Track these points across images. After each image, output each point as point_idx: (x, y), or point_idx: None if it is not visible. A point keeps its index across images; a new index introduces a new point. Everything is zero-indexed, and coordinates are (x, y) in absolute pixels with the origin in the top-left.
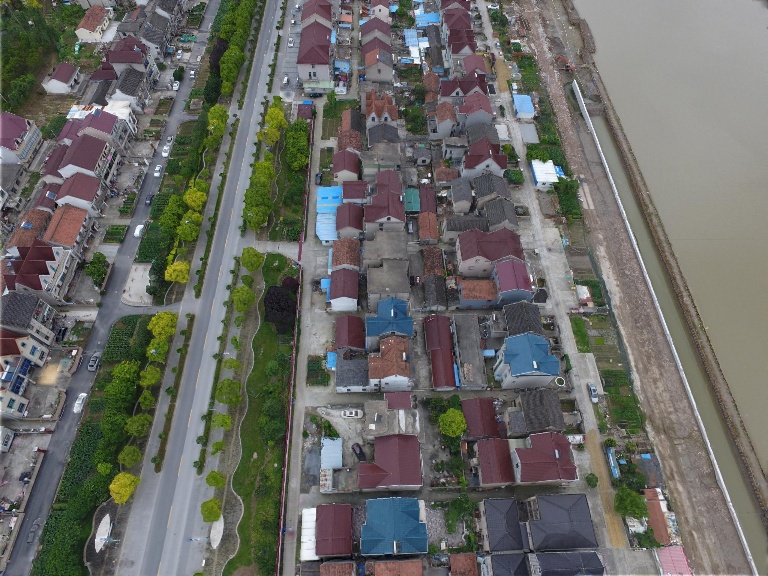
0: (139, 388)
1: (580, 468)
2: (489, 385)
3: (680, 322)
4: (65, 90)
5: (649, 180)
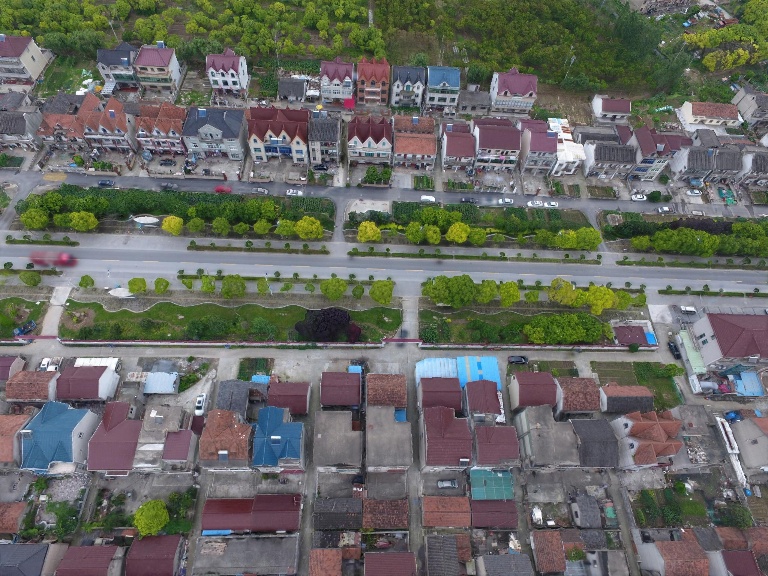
0: None
1: None
2: None
3: None
4: (597, 113)
5: None
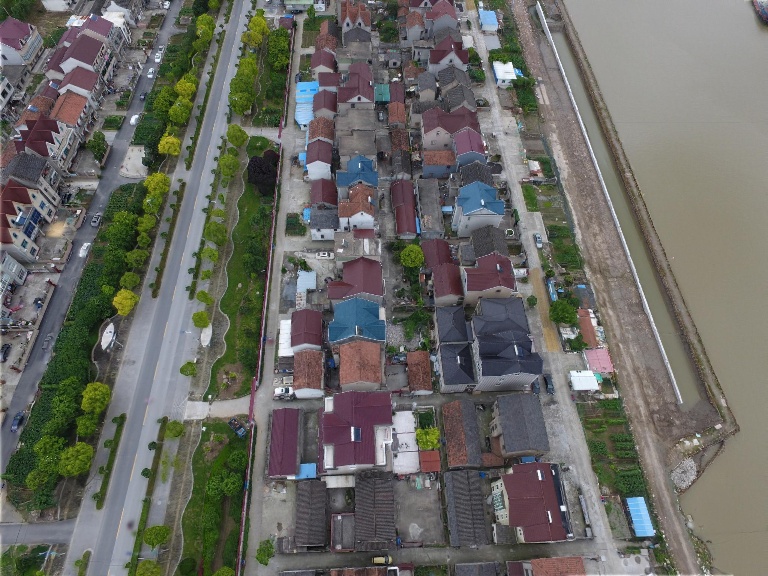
0: (137, 234)
1: (523, 295)
2: (447, 235)
3: (622, 195)
4: (63, 8)
5: None
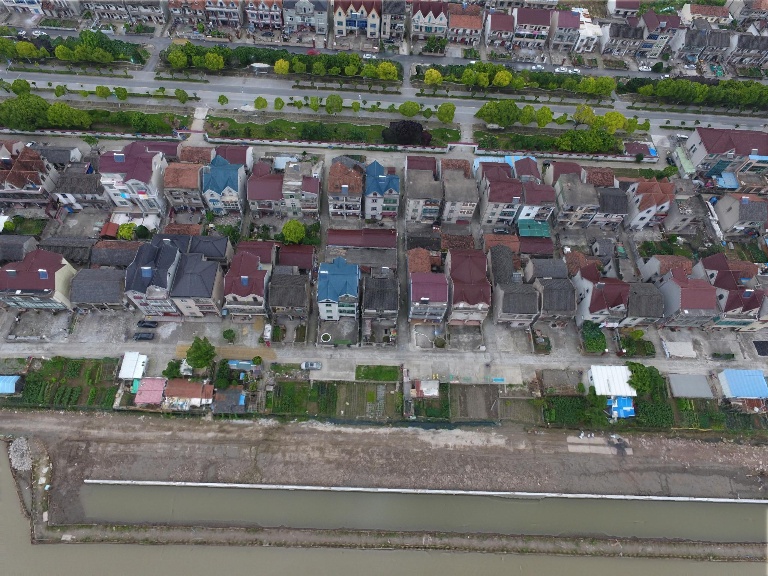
0: None
1: (244, 336)
2: None
3: None
4: (611, 10)
5: (652, 569)
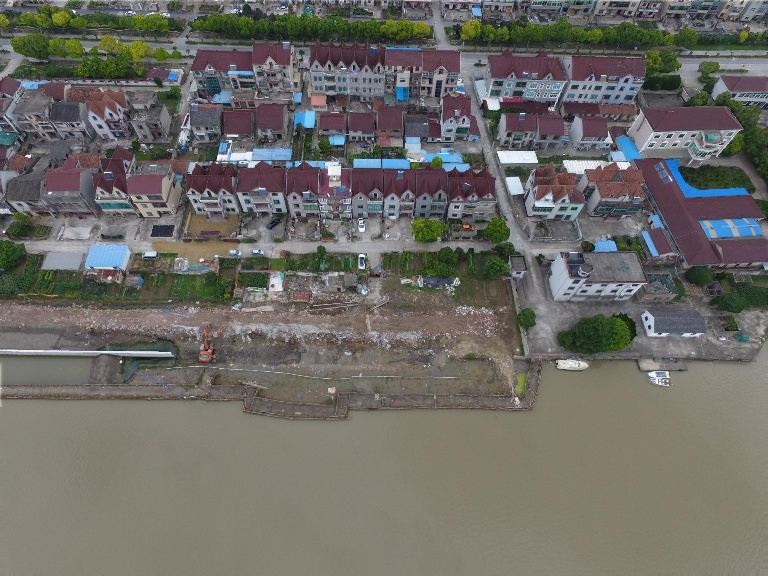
0: None
1: None
2: None
3: None
4: None
5: None
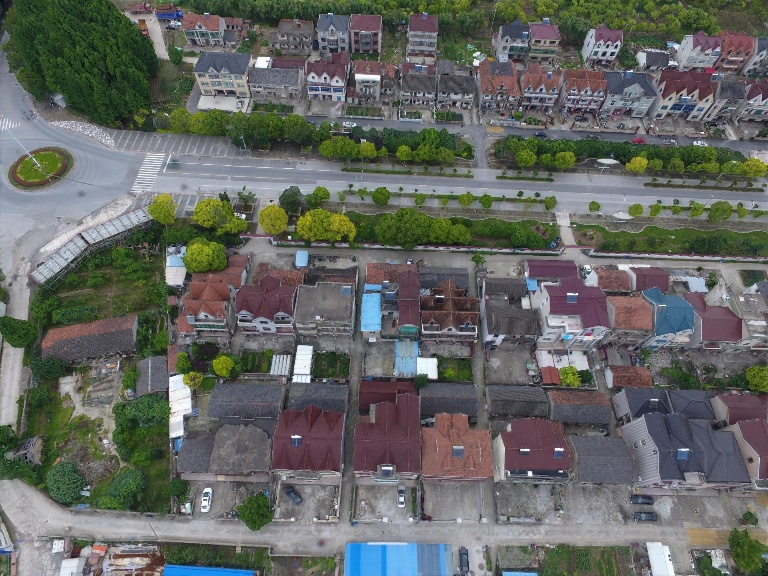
0: None
1: (754, 515)
2: None
3: None
4: None
5: None
